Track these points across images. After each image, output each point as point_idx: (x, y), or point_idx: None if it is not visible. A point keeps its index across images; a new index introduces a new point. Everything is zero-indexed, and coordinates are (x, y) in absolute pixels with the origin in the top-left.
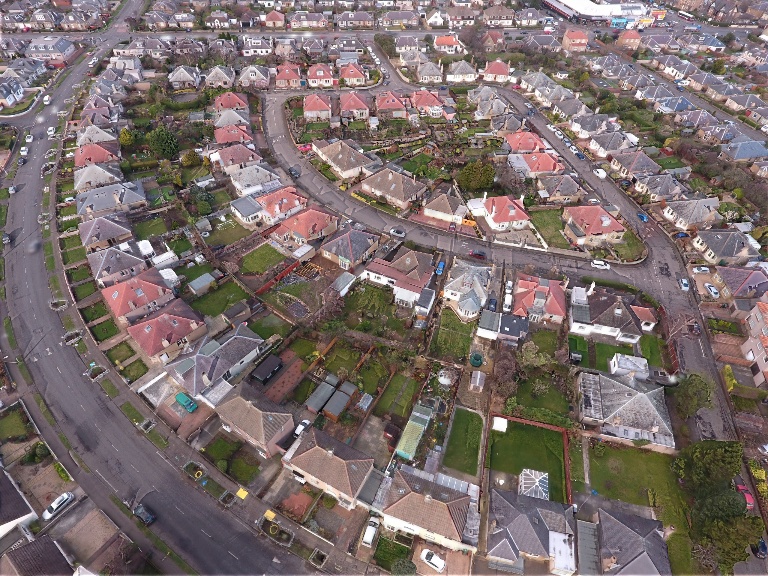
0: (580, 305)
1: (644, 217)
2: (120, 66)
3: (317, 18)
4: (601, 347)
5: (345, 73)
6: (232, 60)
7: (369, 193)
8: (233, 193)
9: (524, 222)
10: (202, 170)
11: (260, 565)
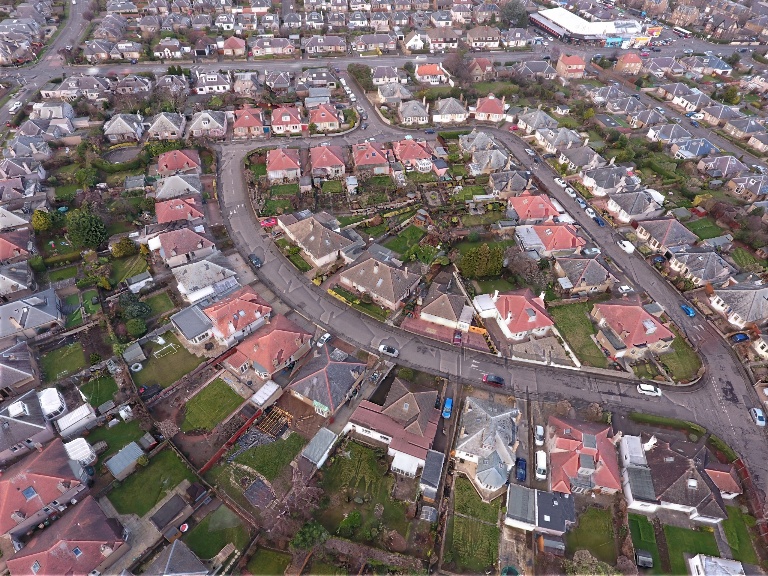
0: (638, 468)
1: (690, 311)
2: (45, 115)
3: (282, 44)
4: (672, 533)
5: (315, 117)
6: (183, 101)
7: (350, 287)
8: (177, 296)
9: (546, 327)
10: (138, 261)
11: None
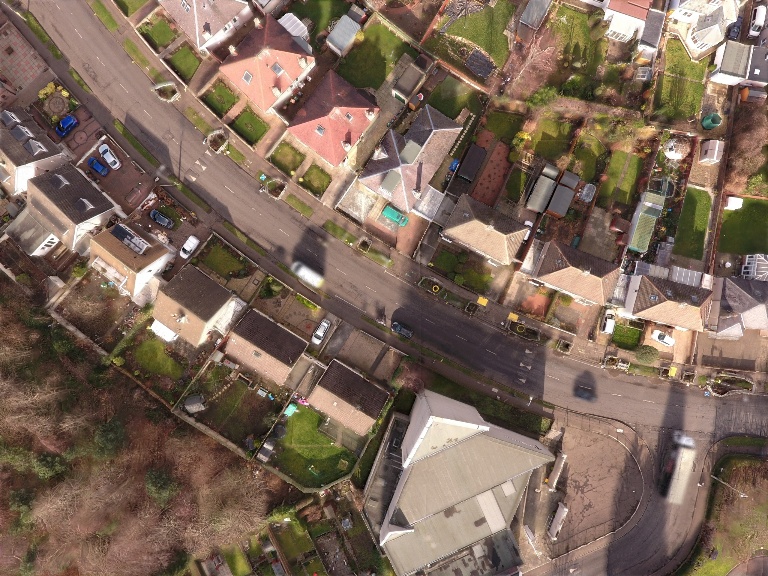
0: None
1: None
2: None
3: None
4: None
5: None
6: None
7: None
8: None
9: None
10: None
11: (516, 357)
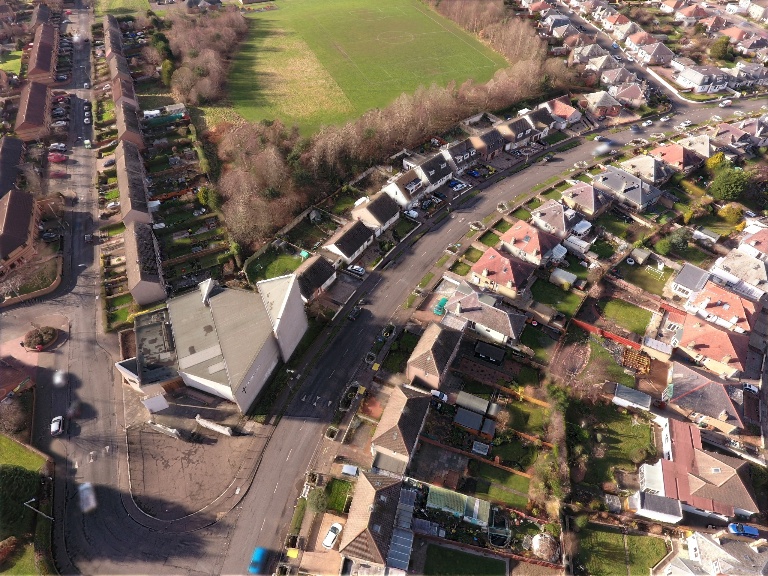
0: None
1: None
2: None
3: None
4: None
5: None
6: None
7: None
8: (710, 263)
9: None
10: (726, 229)
11: (326, 393)
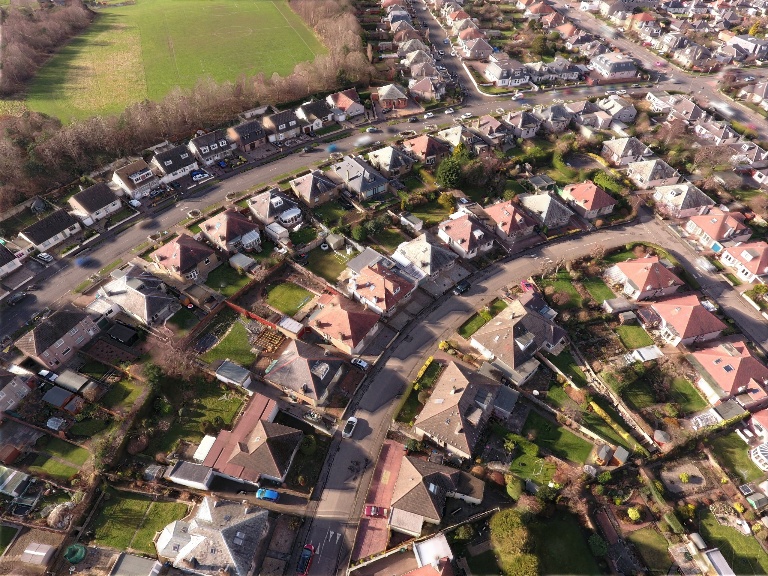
0: None
1: None
2: (608, 106)
3: None
4: None
5: None
6: (719, 170)
7: None
8: None
9: None
10: (440, 215)
11: None
